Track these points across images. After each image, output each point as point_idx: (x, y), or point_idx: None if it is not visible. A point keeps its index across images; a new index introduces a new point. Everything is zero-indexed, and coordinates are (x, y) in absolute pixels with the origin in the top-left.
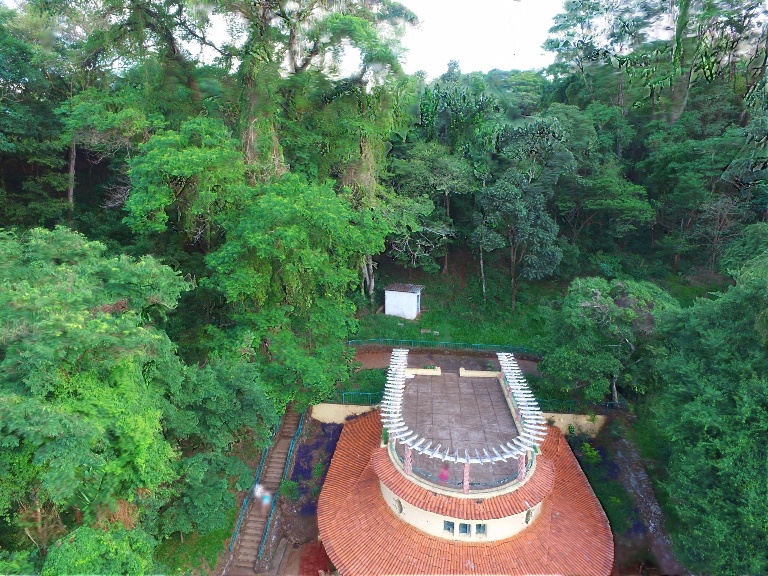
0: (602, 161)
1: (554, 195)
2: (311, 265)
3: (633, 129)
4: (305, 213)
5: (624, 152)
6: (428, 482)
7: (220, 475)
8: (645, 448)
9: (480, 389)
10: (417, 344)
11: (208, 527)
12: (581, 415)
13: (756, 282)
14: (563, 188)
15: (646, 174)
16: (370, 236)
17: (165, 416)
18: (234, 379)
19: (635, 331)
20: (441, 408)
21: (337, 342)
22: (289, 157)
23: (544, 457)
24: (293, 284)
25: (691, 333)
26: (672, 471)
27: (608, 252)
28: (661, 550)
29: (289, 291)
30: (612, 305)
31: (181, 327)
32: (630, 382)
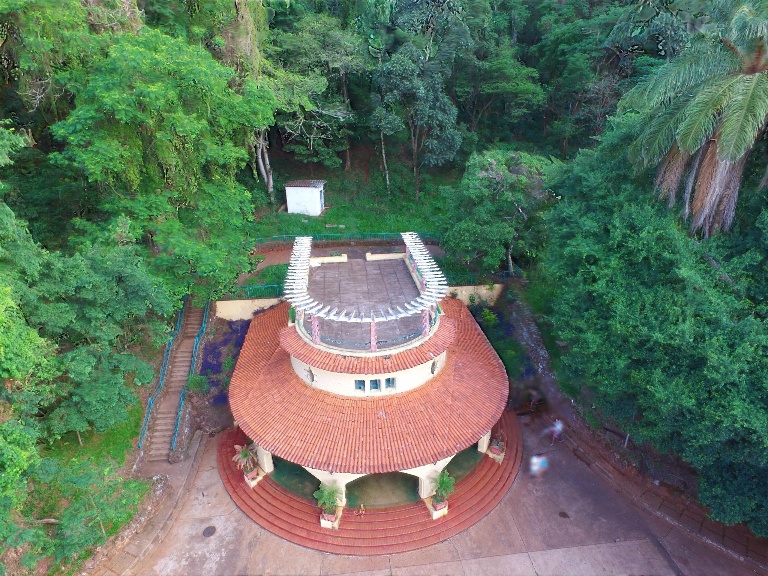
0: (497, 42)
1: (452, 80)
2: (186, 132)
3: (527, 10)
4: (170, 67)
5: (518, 36)
6: (337, 348)
7: (114, 372)
8: (536, 305)
9: (386, 269)
10: (323, 238)
11: (107, 423)
12: (481, 286)
13: (630, 122)
14: (461, 72)
15: (539, 59)
16: (255, 106)
17: (24, 301)
18: (112, 266)
19: None
20: (348, 288)
21: (234, 233)
22: (148, 17)
23: (447, 317)
24: (170, 161)
25: (574, 181)
26: (556, 305)
27: (505, 141)
28: (548, 386)
29: (173, 184)
30: (506, 173)
31: (47, 233)
32: (523, 247)
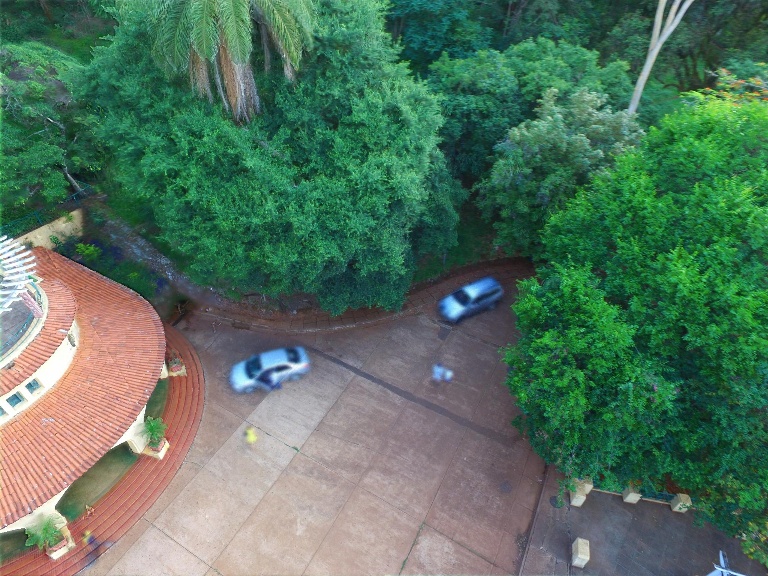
0: None
1: None
2: None
3: None
4: None
5: None
6: None
7: None
8: (130, 219)
9: None
10: None
11: None
12: (55, 221)
13: (134, 17)
14: None
15: None
16: None
17: None
18: None
19: (52, 107)
20: None
21: None
22: None
23: (47, 281)
24: None
25: (108, 89)
26: (161, 223)
27: None
28: (185, 287)
29: None
30: (7, 82)
31: None
32: (81, 164)
